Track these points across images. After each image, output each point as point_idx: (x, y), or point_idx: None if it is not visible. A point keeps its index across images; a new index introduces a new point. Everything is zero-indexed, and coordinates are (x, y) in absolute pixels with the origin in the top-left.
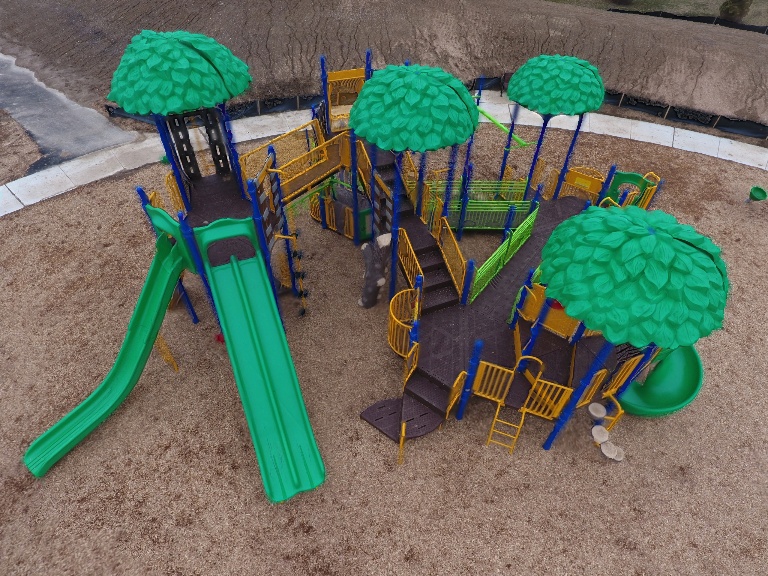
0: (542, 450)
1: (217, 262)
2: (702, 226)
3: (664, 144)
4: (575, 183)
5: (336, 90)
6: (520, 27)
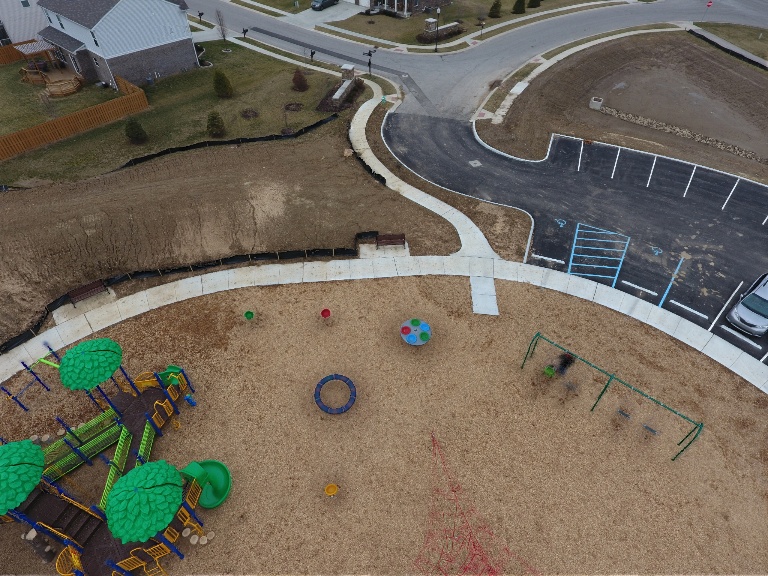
0: (181, 561)
1: None
2: (229, 353)
3: (198, 295)
4: (143, 386)
5: None
6: (60, 238)
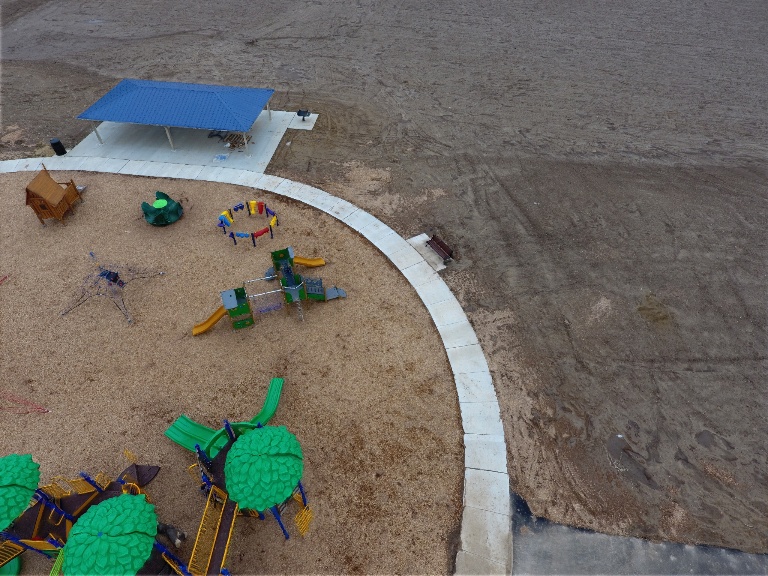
0: None
1: (228, 444)
2: None
3: None
4: None
5: None
6: None
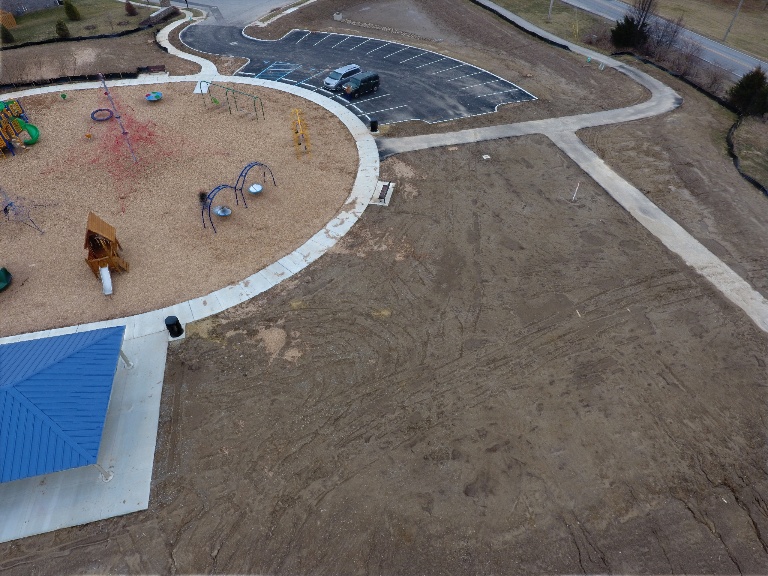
0: None
1: None
2: None
3: (36, 94)
4: None
5: None
6: None
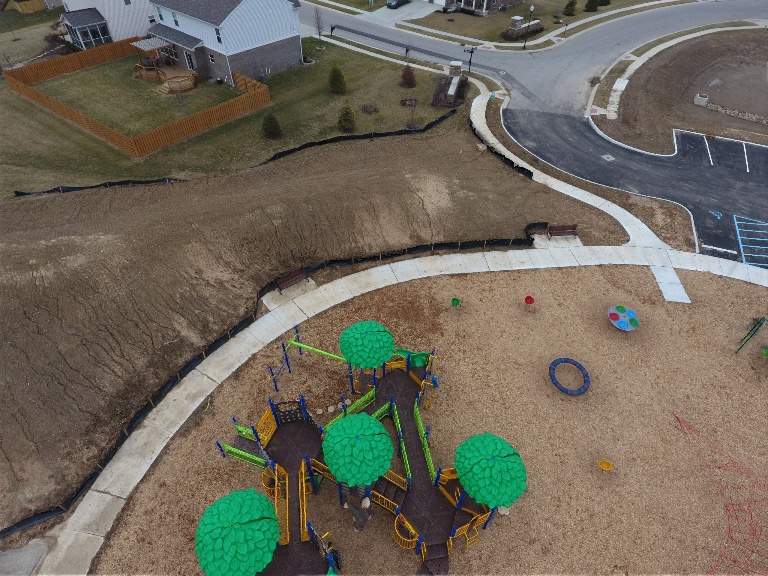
0: (484, 531)
1: None
2: (447, 338)
3: (394, 283)
4: (392, 367)
5: (167, 368)
6: (251, 228)
